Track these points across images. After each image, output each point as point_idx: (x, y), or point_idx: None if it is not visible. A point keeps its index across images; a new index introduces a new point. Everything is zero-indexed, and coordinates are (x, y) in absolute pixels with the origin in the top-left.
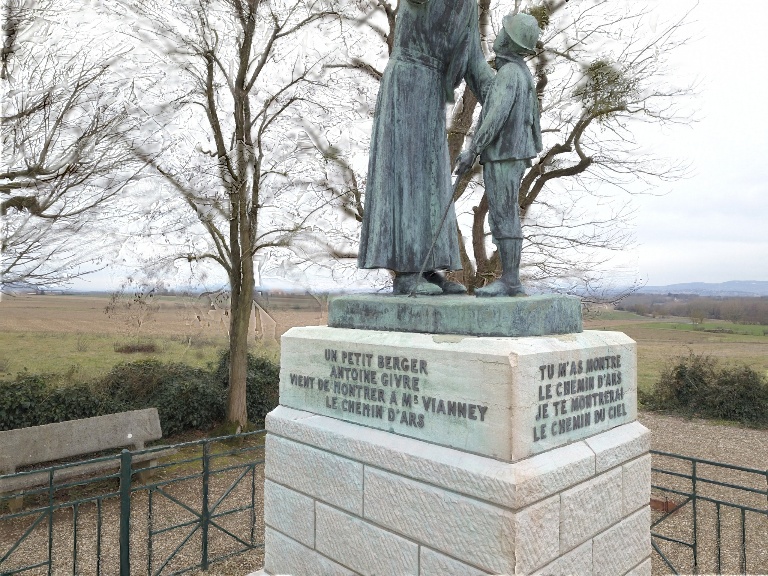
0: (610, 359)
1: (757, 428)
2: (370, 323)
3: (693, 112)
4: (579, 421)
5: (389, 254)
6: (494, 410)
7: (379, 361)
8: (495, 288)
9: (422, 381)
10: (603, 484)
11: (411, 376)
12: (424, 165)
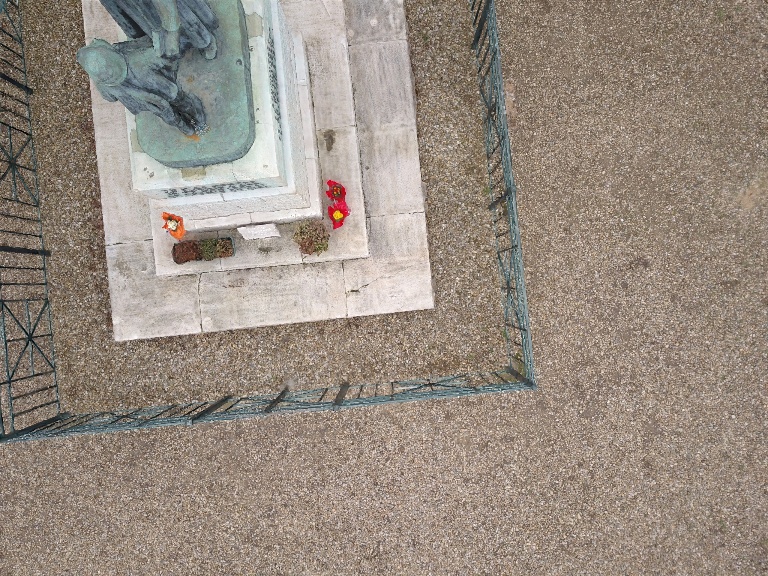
0: (242, 182)
1: None
2: None
3: None
4: (212, 192)
5: (132, 33)
6: None
7: None
8: None
9: None
10: (236, 202)
11: None
12: (128, 5)
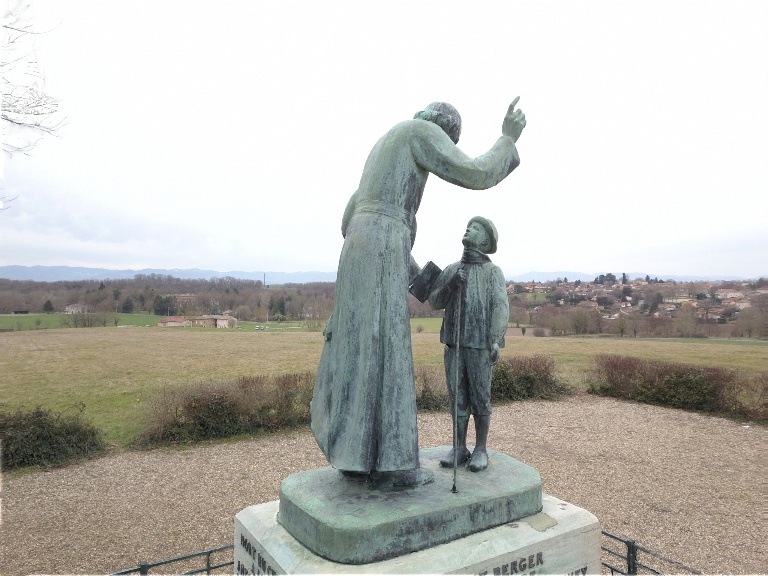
0: None
1: (60, 466)
2: (437, 537)
3: (28, 145)
4: None
5: None
6: (592, 566)
7: (496, 574)
8: (485, 460)
9: (538, 572)
10: None
11: (528, 573)
12: None
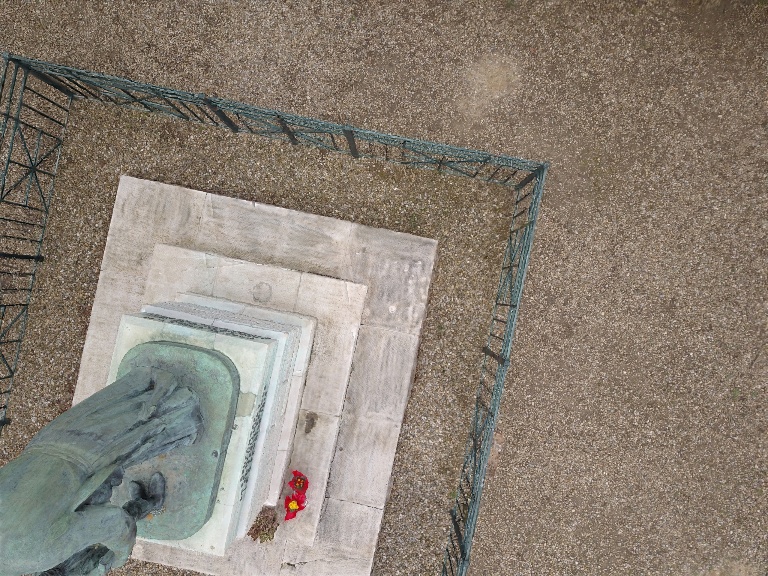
0: None
1: None
2: None
3: None
4: None
5: None
6: None
7: None
8: None
9: None
10: None
11: None
12: None
